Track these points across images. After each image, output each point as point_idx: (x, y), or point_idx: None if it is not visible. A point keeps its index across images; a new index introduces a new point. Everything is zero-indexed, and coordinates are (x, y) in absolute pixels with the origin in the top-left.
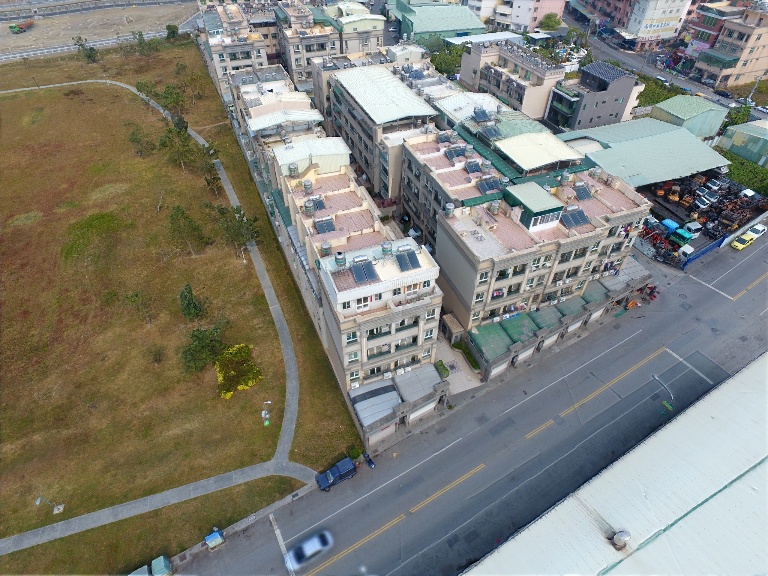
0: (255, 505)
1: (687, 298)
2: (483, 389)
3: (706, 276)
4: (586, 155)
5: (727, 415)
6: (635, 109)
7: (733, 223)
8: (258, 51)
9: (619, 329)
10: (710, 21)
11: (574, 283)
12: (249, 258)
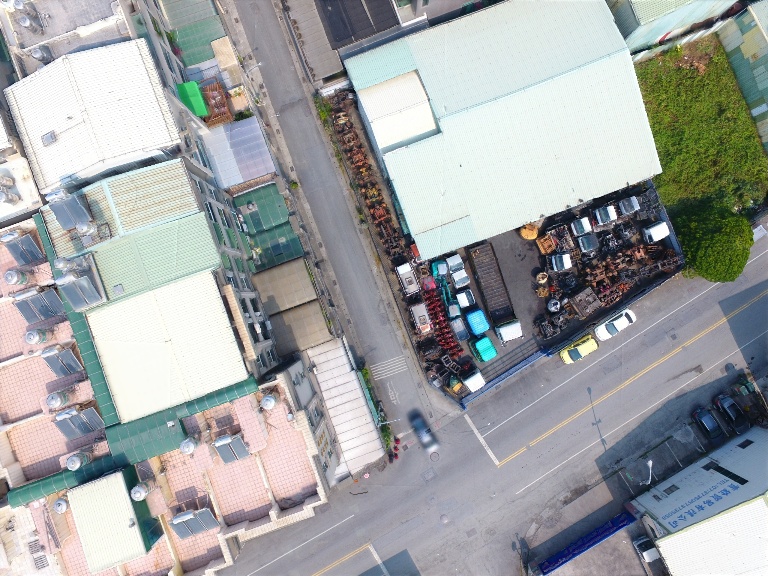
0: None
1: (438, 461)
2: None
3: (487, 418)
4: None
5: None
6: None
7: None
8: None
9: (326, 513)
10: None
11: None
12: None
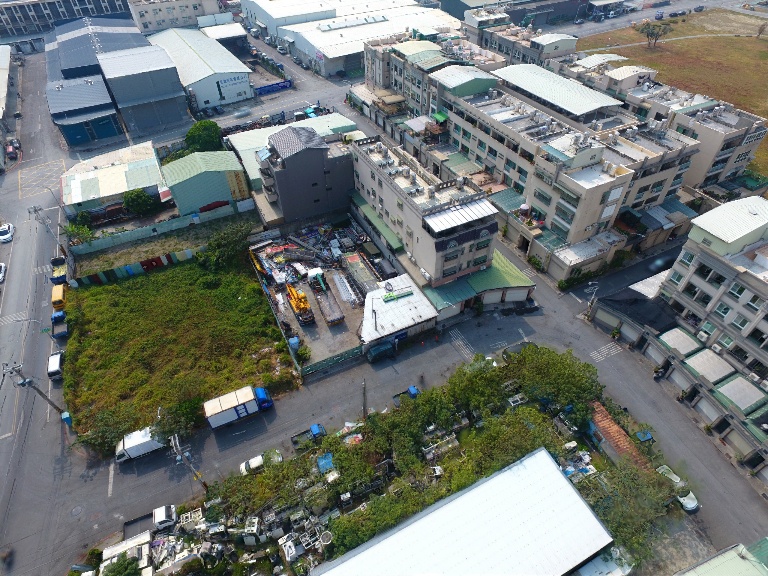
0: None
1: (329, 100)
2: None
3: None
4: None
5: None
6: (221, 240)
7: None
8: None
9: None
10: None
11: None
12: None
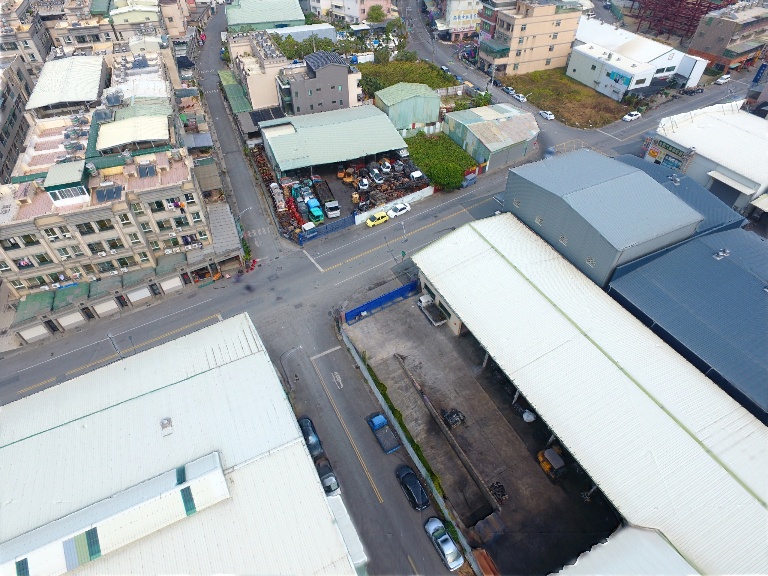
0: None
1: (281, 270)
2: (17, 352)
3: (318, 251)
4: (267, 139)
5: (139, 367)
6: None
7: (376, 202)
8: (25, 42)
9: (191, 298)
10: (489, 12)
11: (128, 254)
12: None
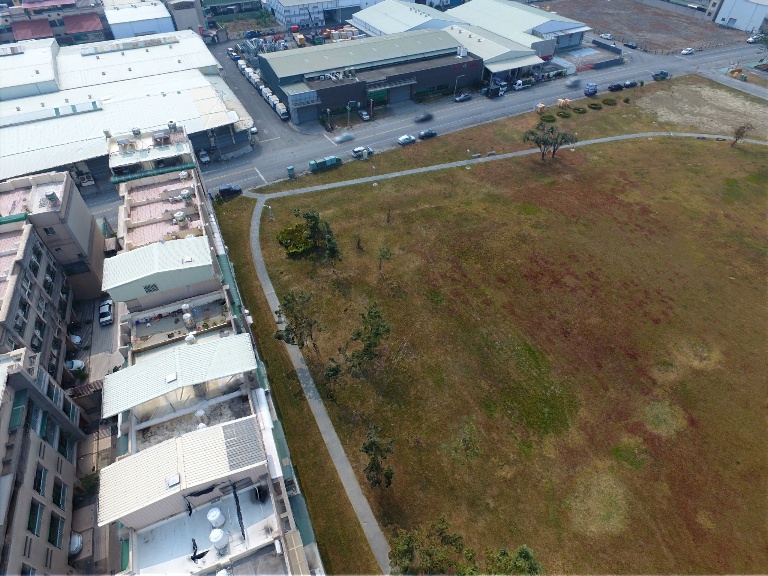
0: (275, 185)
1: None
2: None
3: None
4: None
5: None
6: None
7: None
8: None
9: None
10: None
11: None
12: (302, 349)
